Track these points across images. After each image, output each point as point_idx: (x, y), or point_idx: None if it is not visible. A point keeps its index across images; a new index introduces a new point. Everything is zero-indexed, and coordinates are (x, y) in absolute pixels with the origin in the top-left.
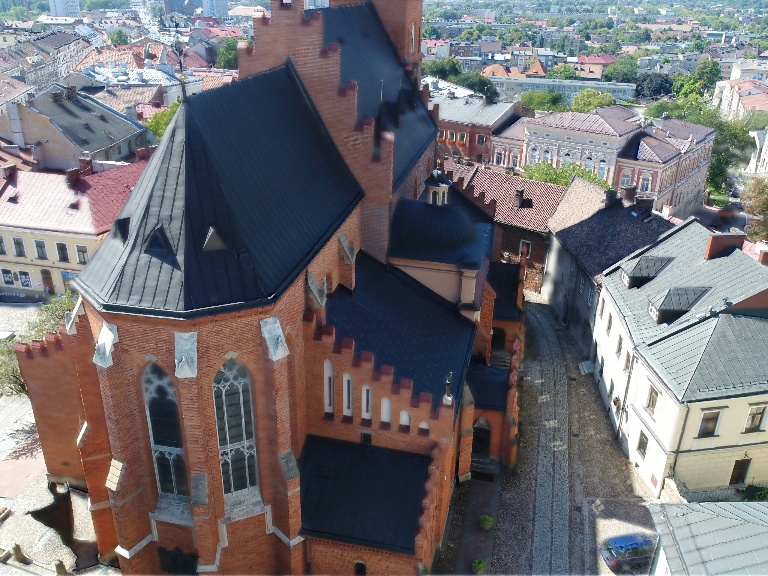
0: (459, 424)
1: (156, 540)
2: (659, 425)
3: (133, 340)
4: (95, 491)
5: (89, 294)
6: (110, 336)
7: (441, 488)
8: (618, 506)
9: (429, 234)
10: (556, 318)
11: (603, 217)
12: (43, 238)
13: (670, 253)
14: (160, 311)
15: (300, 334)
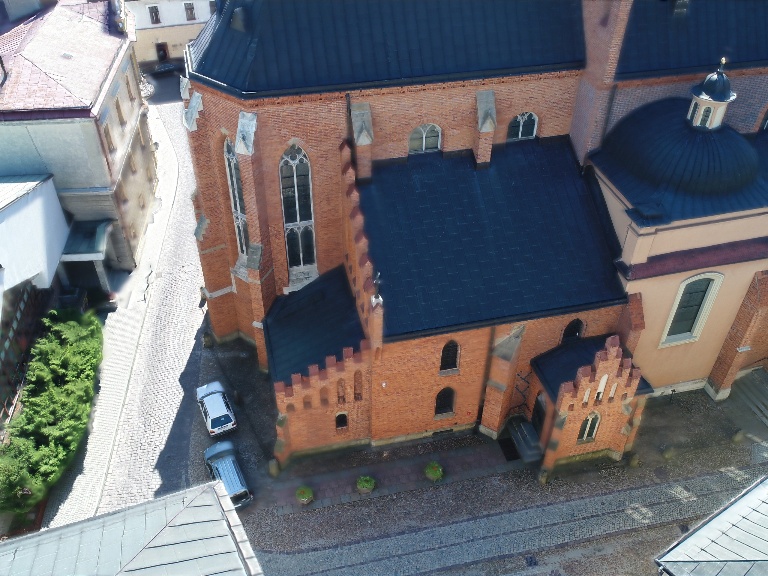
0: (486, 369)
1: None
2: None
3: None
4: None
5: None
6: None
7: None
8: None
9: (641, 153)
10: None
11: None
12: None
13: None
14: None
15: (333, 159)
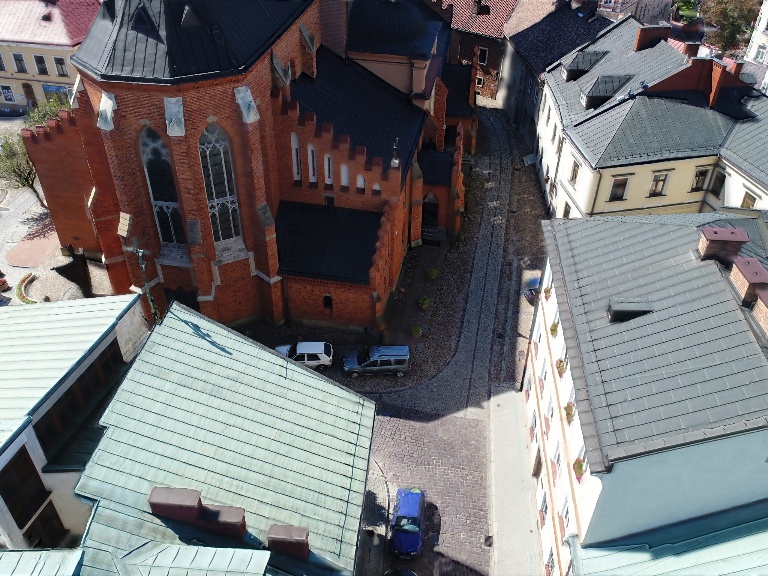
0: (410, 195)
1: (162, 282)
2: (579, 193)
3: (129, 107)
4: (107, 248)
5: (87, 68)
6: (110, 103)
7: (392, 240)
8: (542, 261)
9: (383, 28)
10: (508, 120)
11: (553, 19)
12: (20, 51)
13: (606, 48)
14: (150, 79)
15: (269, 109)
